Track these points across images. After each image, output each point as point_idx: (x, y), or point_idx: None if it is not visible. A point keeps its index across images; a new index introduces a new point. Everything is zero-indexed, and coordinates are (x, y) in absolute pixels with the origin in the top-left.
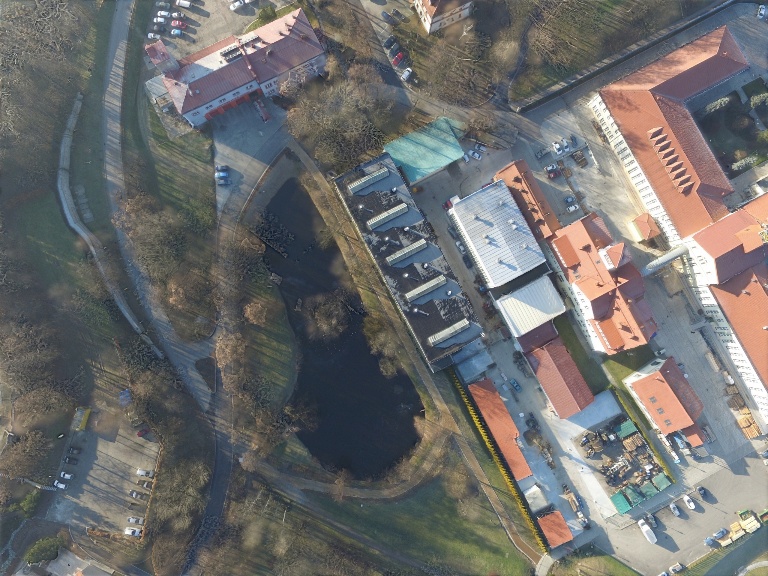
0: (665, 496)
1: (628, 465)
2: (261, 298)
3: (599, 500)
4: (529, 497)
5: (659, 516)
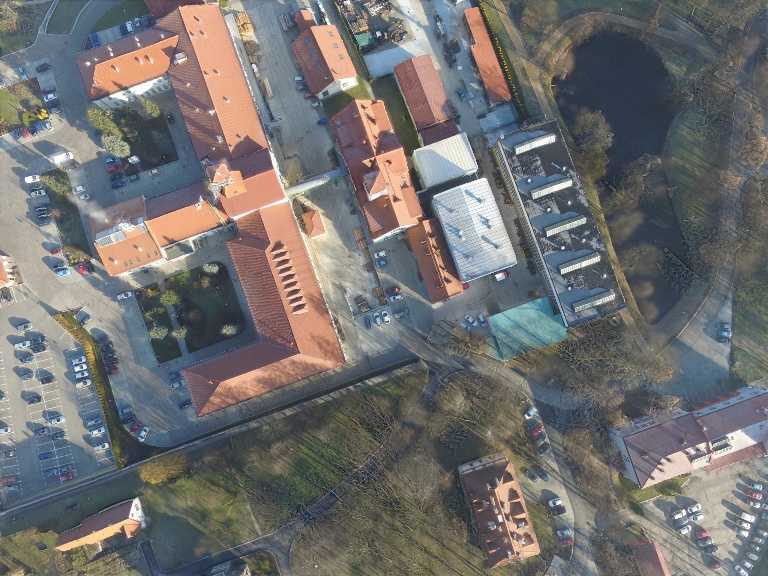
0: None
1: (368, 7)
2: (696, 210)
3: None
4: None
5: None
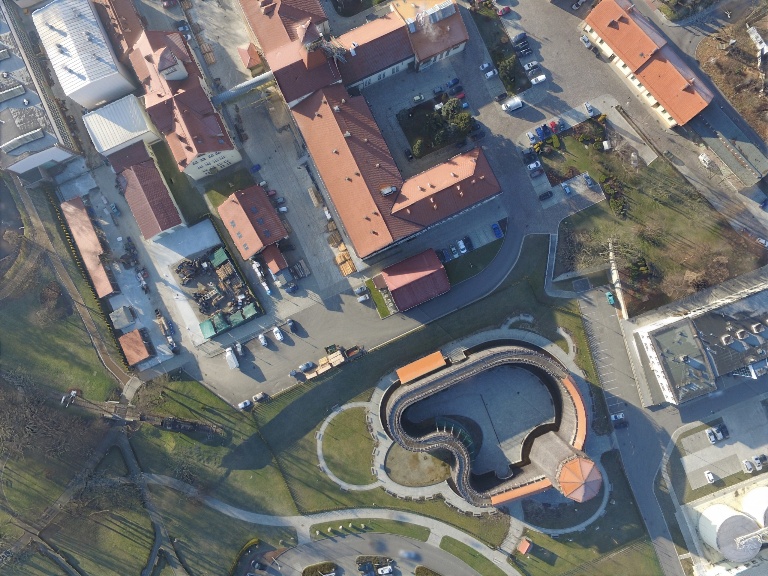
0: (256, 327)
1: (217, 292)
2: None
3: (192, 327)
4: (113, 315)
5: (249, 346)
